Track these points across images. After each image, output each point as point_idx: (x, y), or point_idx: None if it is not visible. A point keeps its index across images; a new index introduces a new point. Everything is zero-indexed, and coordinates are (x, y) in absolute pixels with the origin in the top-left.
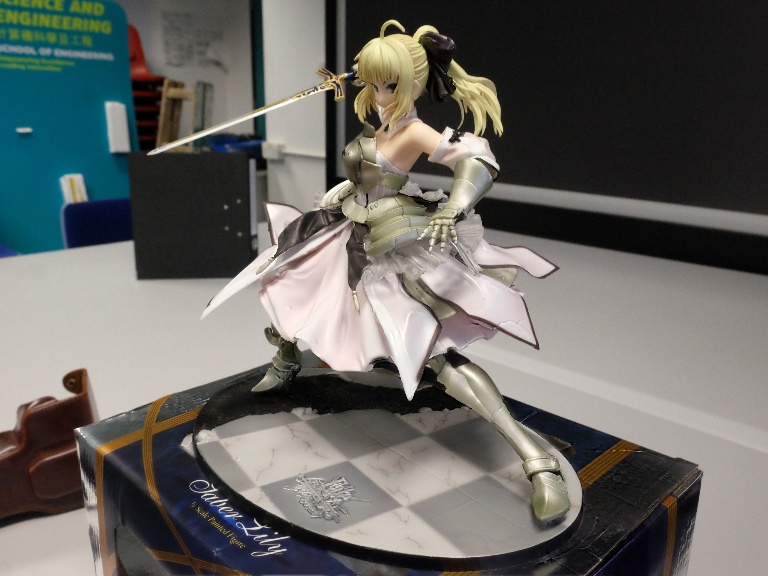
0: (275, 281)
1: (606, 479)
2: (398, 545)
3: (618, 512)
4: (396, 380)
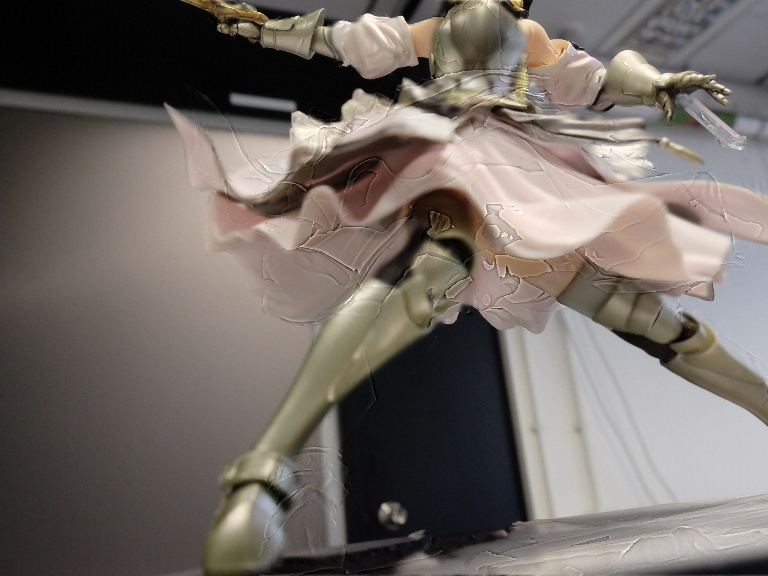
0: None
1: None
2: None
3: None
4: None
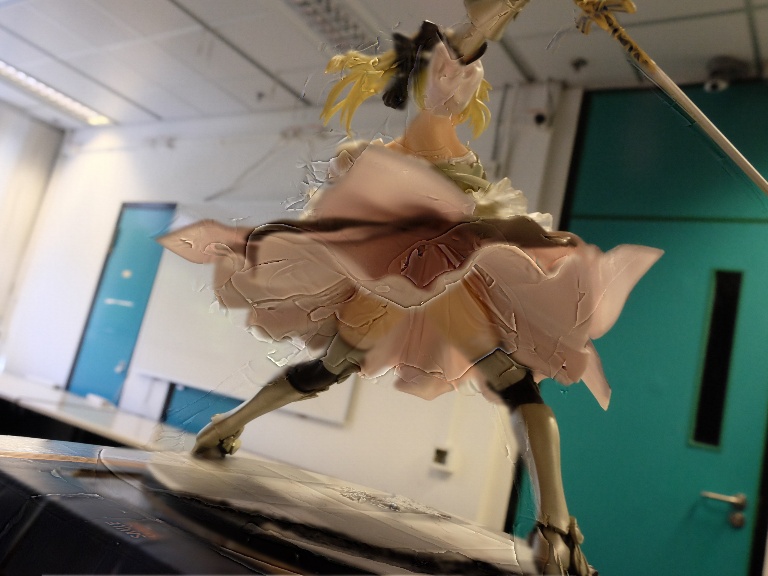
0: (509, 342)
1: (60, 453)
2: (297, 472)
3: (85, 447)
4: (324, 552)
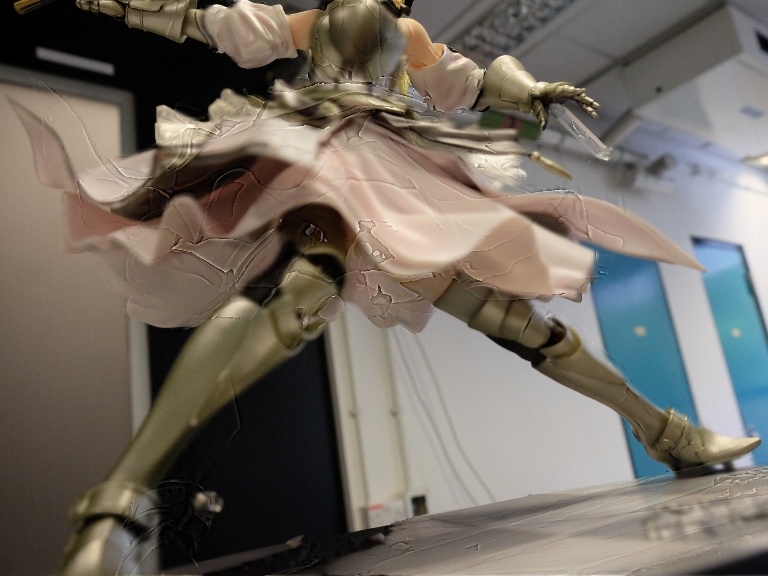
0: None
1: None
2: None
3: None
4: None
